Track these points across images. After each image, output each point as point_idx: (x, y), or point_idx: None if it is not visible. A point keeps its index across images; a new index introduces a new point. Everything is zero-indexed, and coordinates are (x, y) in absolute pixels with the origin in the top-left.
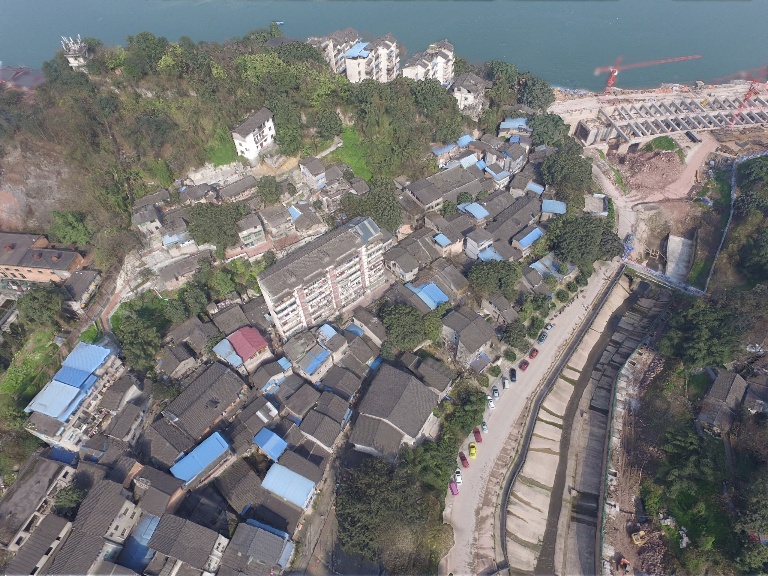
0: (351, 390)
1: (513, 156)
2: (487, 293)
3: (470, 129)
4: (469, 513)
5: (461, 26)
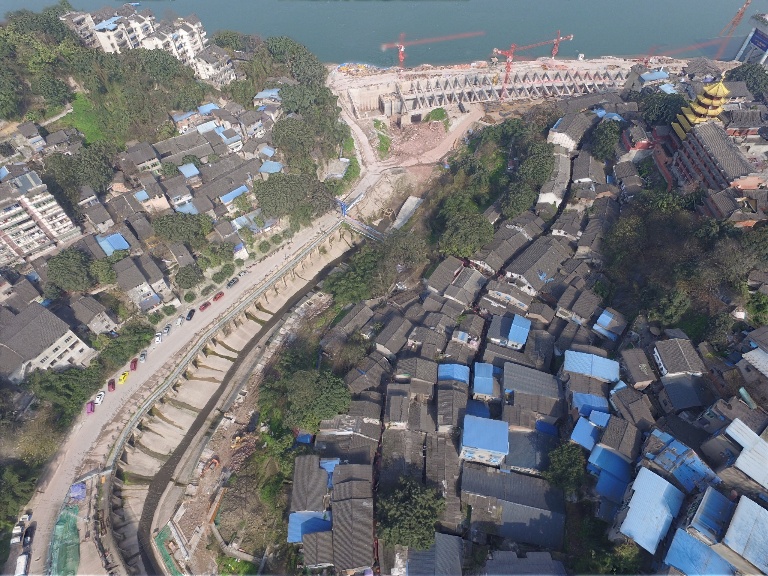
0: (3, 325)
1: (245, 122)
2: (170, 242)
3: (216, 98)
4: (96, 428)
5: (308, 7)
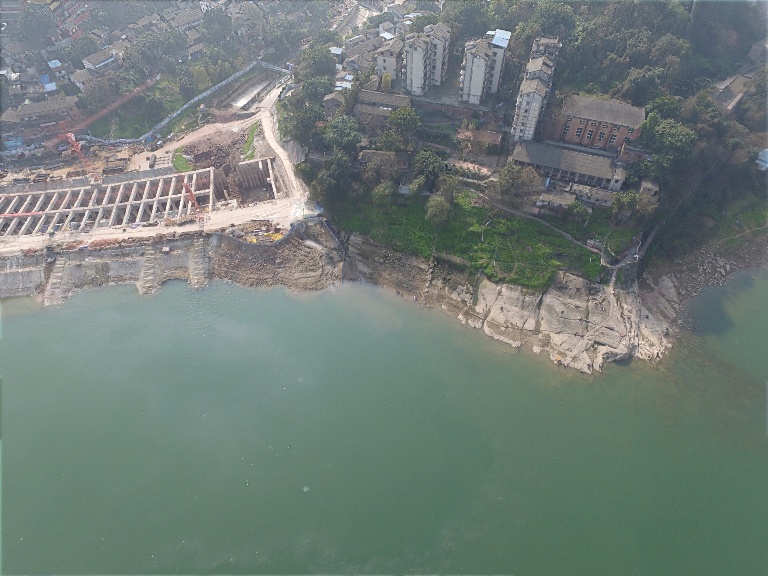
0: None
1: None
2: None
3: None
4: None
5: (362, 549)
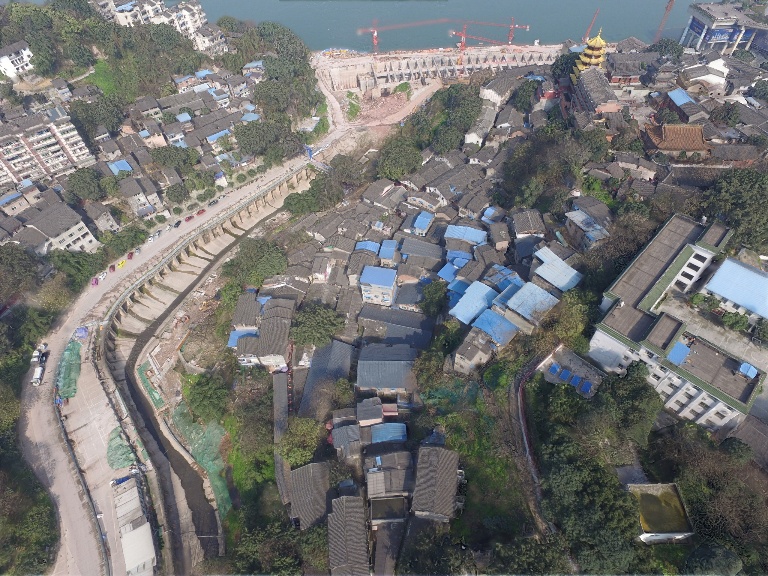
0: None
1: (232, 83)
2: (164, 167)
3: (210, 66)
4: (99, 295)
5: (306, 7)
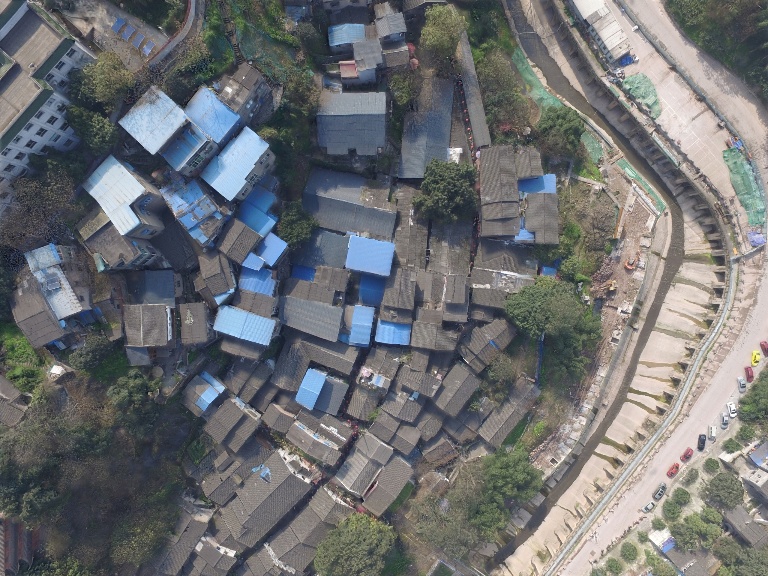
0: None
1: None
2: None
3: None
4: (763, 301)
5: None
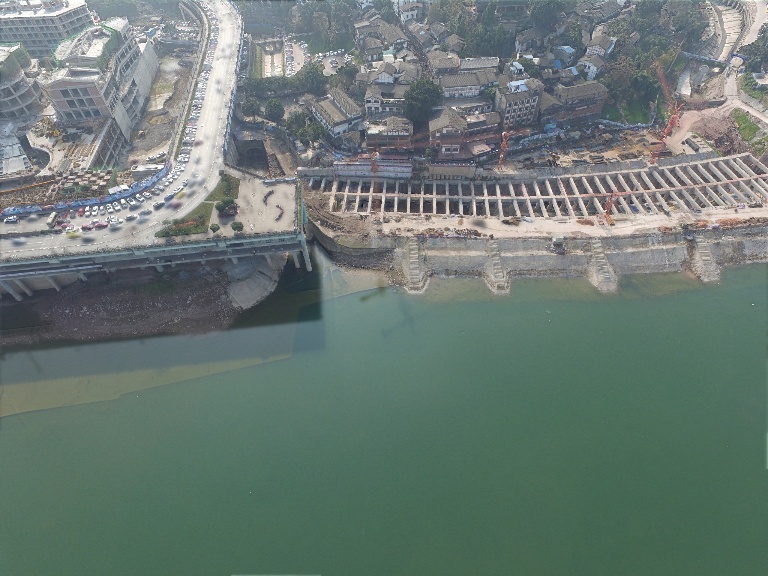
0: None
1: None
2: None
3: None
4: (759, 3)
5: None
